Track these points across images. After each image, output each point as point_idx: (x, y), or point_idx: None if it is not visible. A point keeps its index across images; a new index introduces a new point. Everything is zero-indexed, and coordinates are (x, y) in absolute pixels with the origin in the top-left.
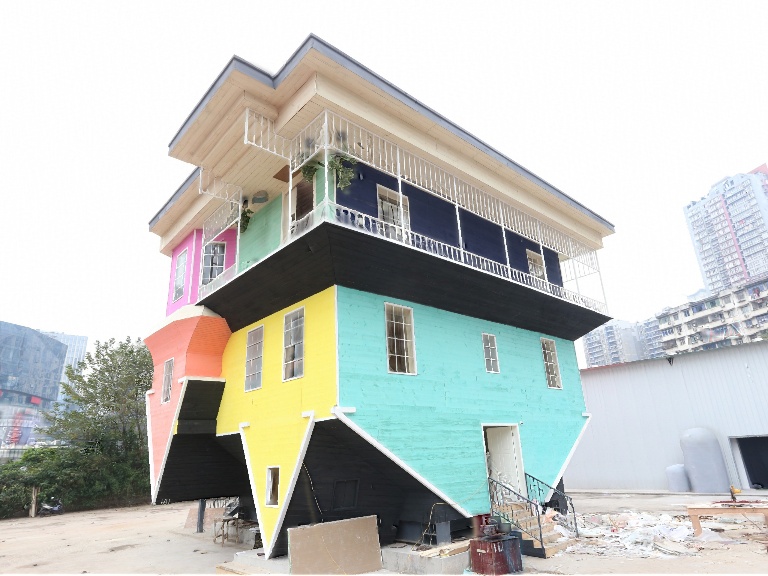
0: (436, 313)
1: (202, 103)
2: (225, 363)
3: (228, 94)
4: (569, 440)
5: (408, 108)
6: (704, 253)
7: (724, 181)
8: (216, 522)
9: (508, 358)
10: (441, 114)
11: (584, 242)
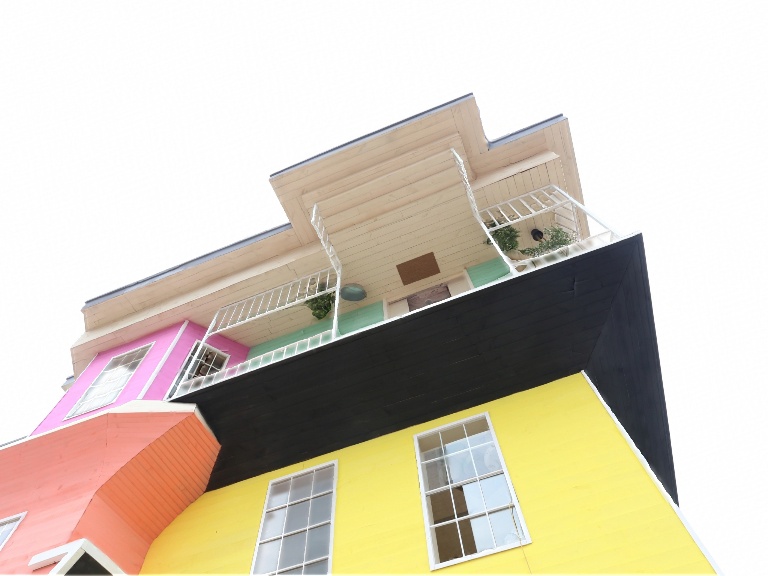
0: None
1: (383, 130)
2: (160, 559)
3: (435, 127)
4: None
5: None
6: None
7: None
8: None
9: None
10: None
11: None
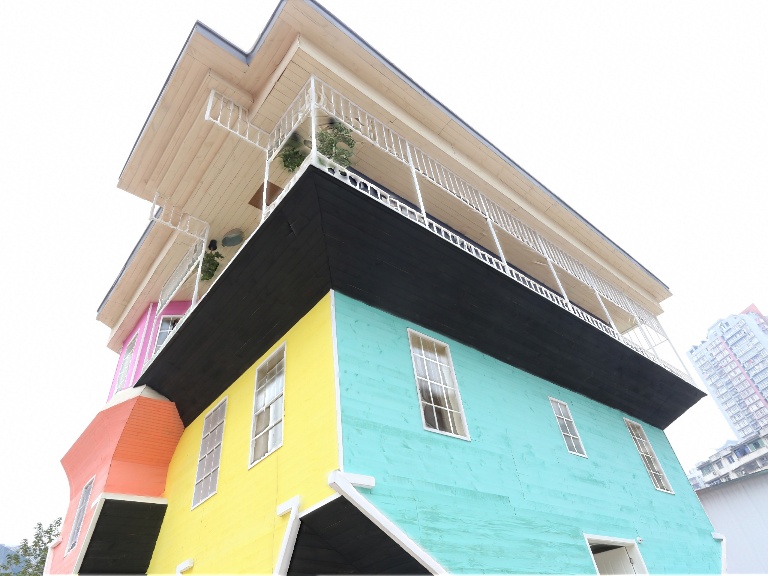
0: (482, 358)
1: (158, 100)
2: (170, 476)
3: (189, 76)
4: (712, 575)
5: (415, 94)
6: (722, 397)
7: (719, 323)
8: None
9: (592, 438)
10: (455, 113)
11: (640, 303)
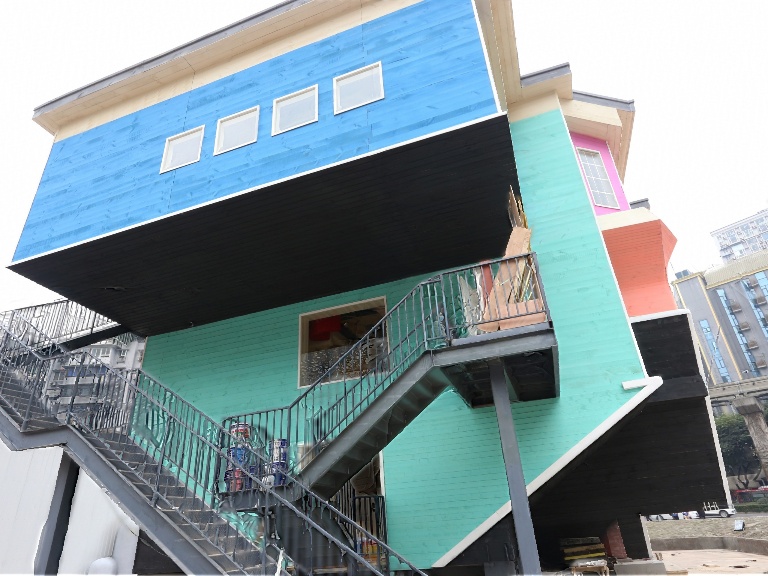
0: None
1: None
2: None
3: None
4: None
5: None
6: None
7: None
8: (602, 575)
9: None
10: None
11: None
